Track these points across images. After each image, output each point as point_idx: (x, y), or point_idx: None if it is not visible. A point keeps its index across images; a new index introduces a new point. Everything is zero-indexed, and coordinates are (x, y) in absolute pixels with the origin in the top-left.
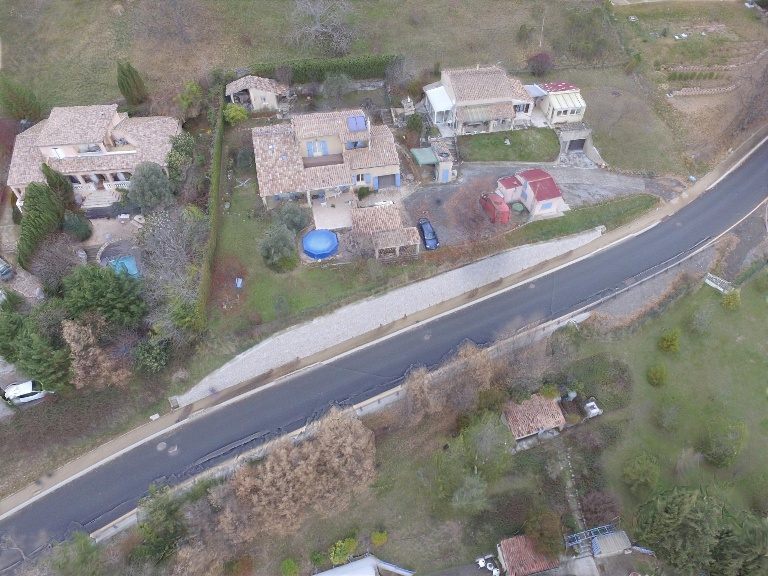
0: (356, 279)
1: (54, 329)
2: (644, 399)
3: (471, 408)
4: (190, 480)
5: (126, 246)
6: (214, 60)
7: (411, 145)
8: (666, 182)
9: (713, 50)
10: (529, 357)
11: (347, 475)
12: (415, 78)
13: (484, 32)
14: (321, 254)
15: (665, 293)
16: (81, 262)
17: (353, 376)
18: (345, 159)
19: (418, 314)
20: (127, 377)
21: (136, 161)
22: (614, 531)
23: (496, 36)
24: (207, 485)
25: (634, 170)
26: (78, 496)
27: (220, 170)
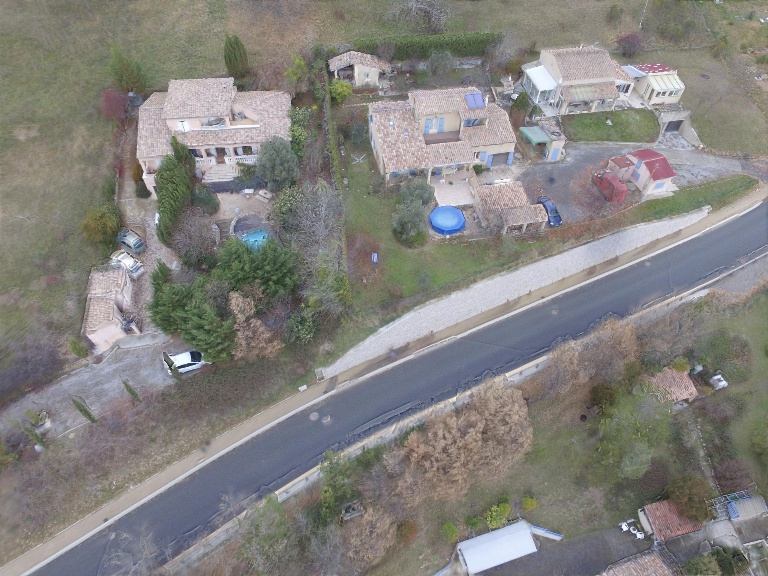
0: (487, 255)
1: (220, 300)
2: (765, 372)
3: (618, 379)
4: (359, 447)
5: (256, 220)
6: (308, 35)
7: (517, 124)
8: (761, 164)
9: None
10: (655, 332)
11: (510, 442)
12: None
13: (575, 12)
14: (450, 230)
15: None
16: (217, 236)
17: (489, 349)
18: (464, 136)
19: (542, 290)
20: (277, 349)
21: (260, 135)
22: (752, 496)
23: (587, 16)
24: (383, 451)
25: (730, 152)
26: (242, 464)
27: None
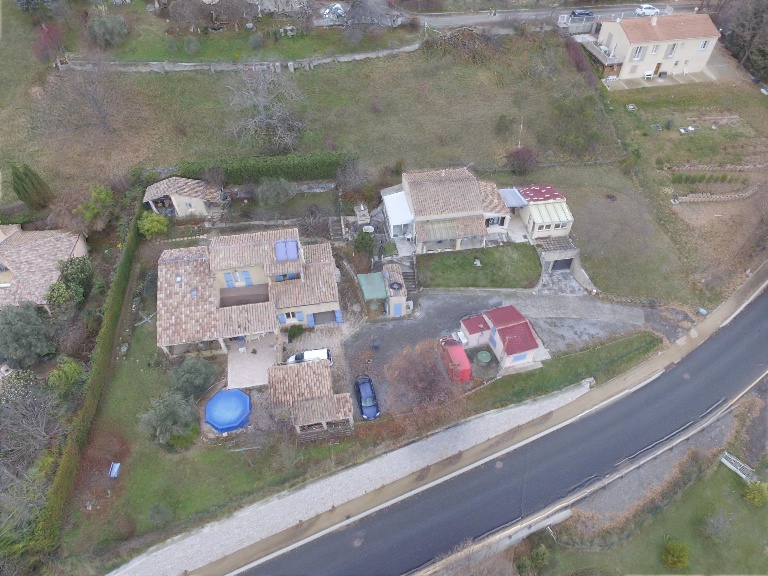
0: (268, 465)
1: None
2: None
3: None
4: None
5: None
6: (142, 152)
7: (360, 266)
8: (671, 314)
9: (725, 147)
10: None
11: None
12: (374, 177)
13: (457, 122)
14: (226, 428)
15: (670, 479)
16: None
17: None
18: (270, 294)
19: (350, 504)
20: None
21: (8, 297)
22: None
23: (471, 127)
24: None
25: (631, 298)
26: None
27: (124, 298)
